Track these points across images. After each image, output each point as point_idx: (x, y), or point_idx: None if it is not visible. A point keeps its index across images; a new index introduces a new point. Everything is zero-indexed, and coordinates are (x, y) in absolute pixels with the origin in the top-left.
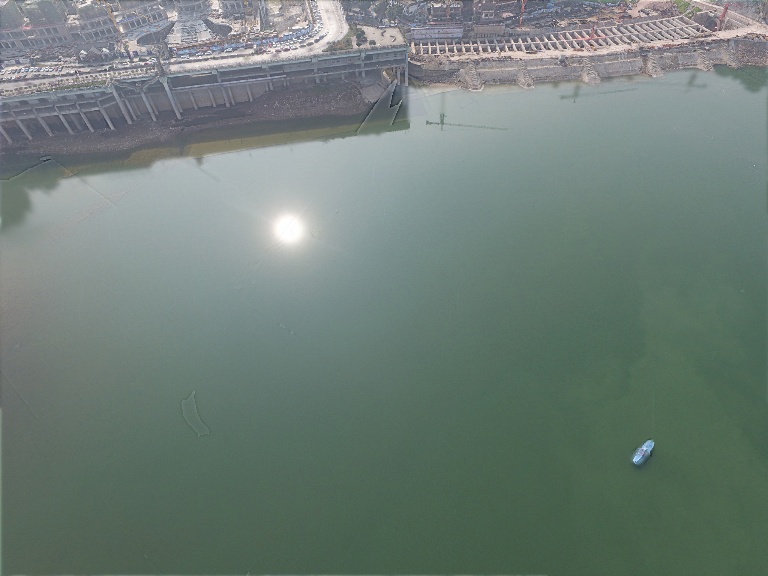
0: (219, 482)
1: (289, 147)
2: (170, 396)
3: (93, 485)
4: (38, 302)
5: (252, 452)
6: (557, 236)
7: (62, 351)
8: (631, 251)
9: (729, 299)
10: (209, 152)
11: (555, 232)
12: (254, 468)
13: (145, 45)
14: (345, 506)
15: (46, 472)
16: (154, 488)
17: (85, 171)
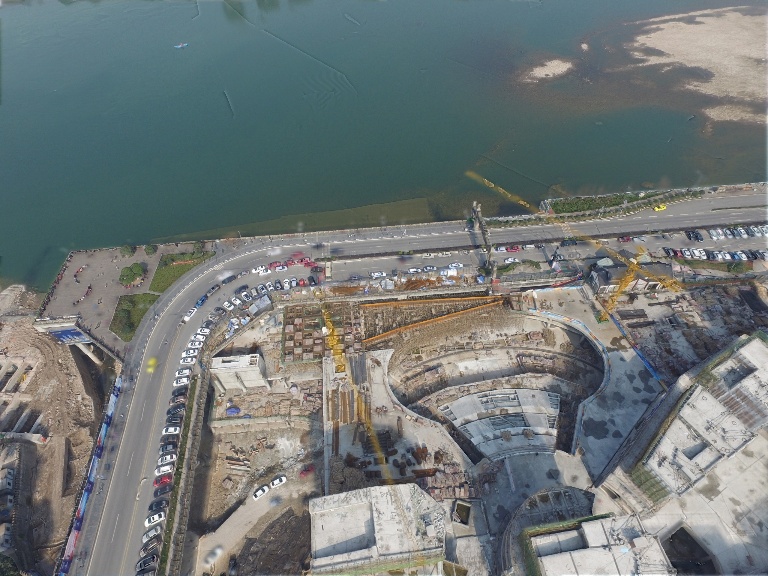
0: (353, 43)
1: (311, 209)
2: (389, 78)
3: (412, 55)
4: (487, 95)
5: (340, 49)
6: (126, 112)
7: (452, 77)
8: (89, 107)
9: (68, 88)
10: (404, 205)
11: (124, 114)
12: (339, 46)
13: (559, 315)
14: (304, 42)
15: (434, 55)
16: (382, 47)
17: (541, 191)
